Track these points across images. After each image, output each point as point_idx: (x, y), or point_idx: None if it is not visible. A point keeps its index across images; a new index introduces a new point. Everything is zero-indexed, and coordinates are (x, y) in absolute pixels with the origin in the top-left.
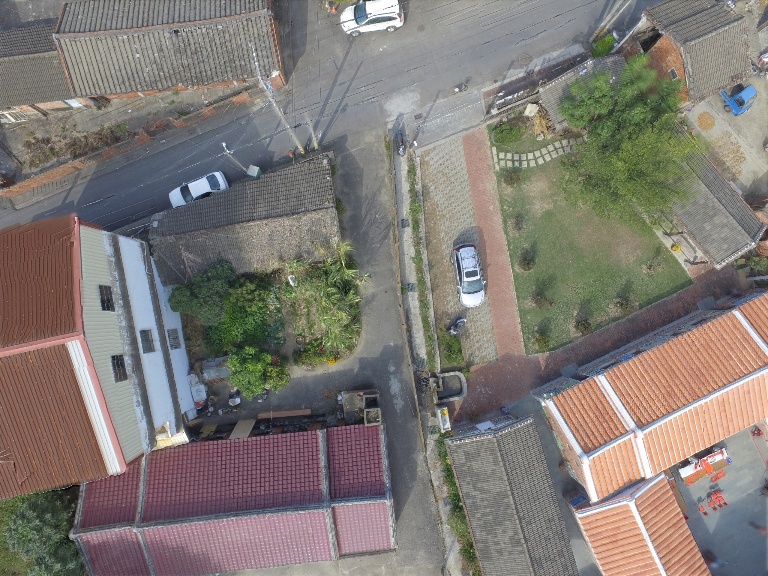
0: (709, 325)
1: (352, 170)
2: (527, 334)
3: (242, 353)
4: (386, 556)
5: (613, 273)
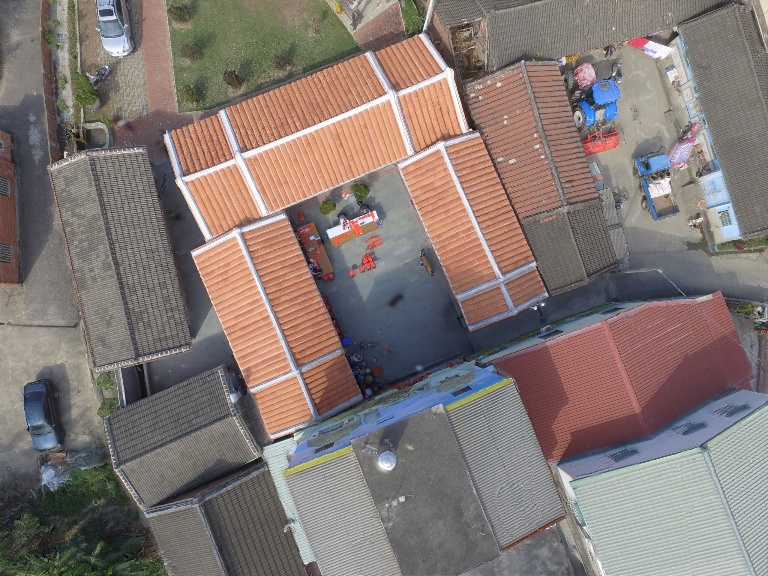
0: (339, 66)
1: None
2: None
3: None
4: (14, 309)
5: (277, 35)
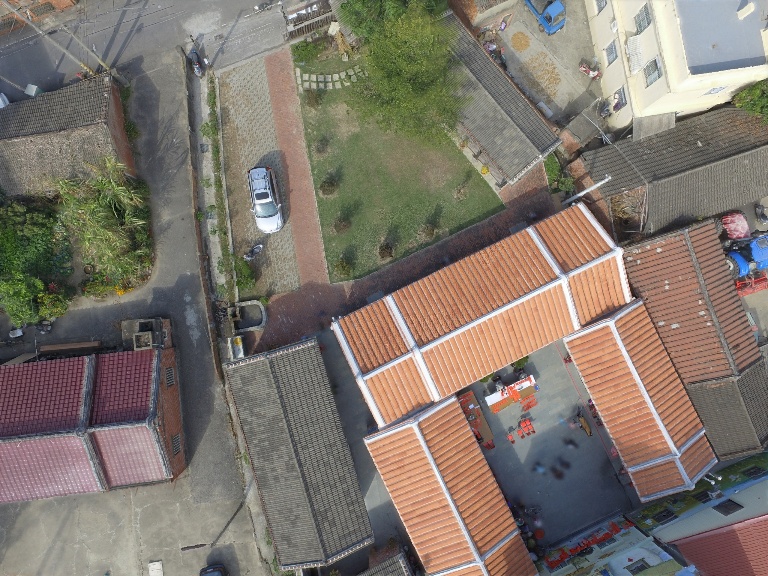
0: (502, 243)
1: (148, 93)
2: (332, 262)
3: (13, 279)
4: (181, 492)
5: (422, 198)
